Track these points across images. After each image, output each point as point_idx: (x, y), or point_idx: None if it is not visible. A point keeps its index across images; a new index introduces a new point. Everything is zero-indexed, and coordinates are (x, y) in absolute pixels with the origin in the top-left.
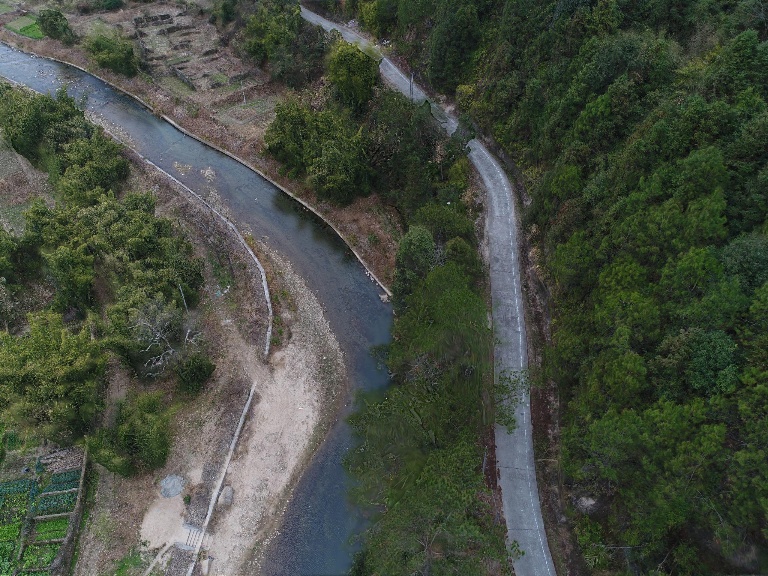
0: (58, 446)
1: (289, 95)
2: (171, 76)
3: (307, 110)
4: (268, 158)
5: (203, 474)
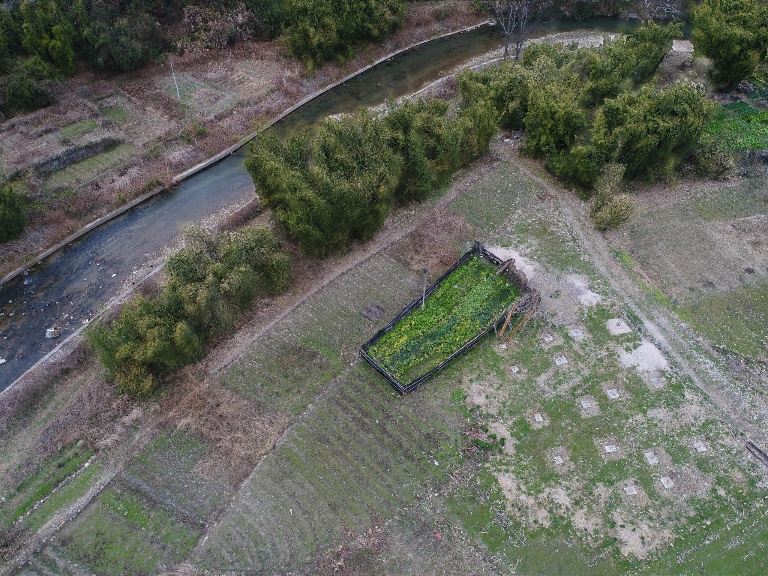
0: (735, 92)
1: (175, 60)
2: (45, 179)
3: (239, 34)
4: (312, 75)
5: None
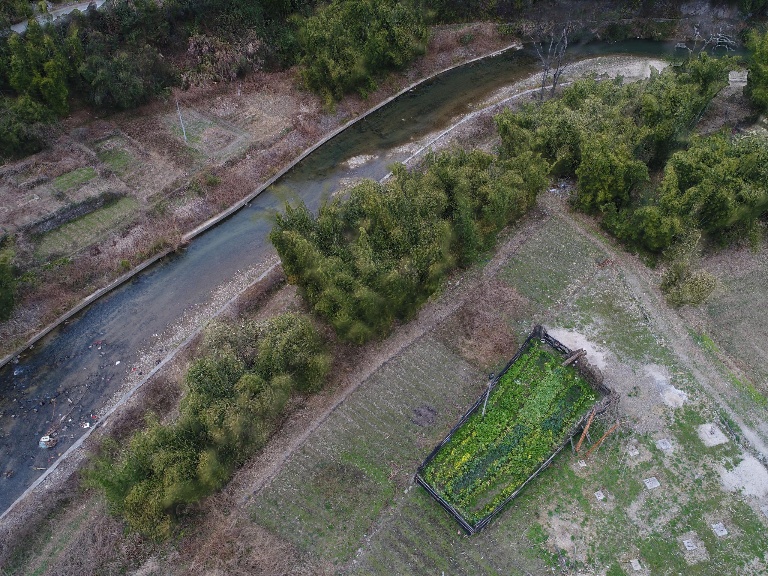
0: None
1: (180, 95)
2: (37, 243)
3: (250, 65)
4: (330, 110)
5: (740, 82)
